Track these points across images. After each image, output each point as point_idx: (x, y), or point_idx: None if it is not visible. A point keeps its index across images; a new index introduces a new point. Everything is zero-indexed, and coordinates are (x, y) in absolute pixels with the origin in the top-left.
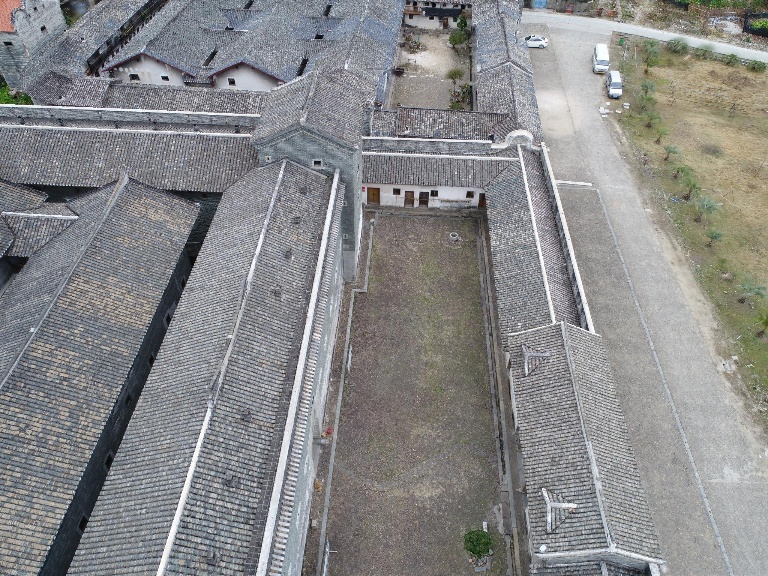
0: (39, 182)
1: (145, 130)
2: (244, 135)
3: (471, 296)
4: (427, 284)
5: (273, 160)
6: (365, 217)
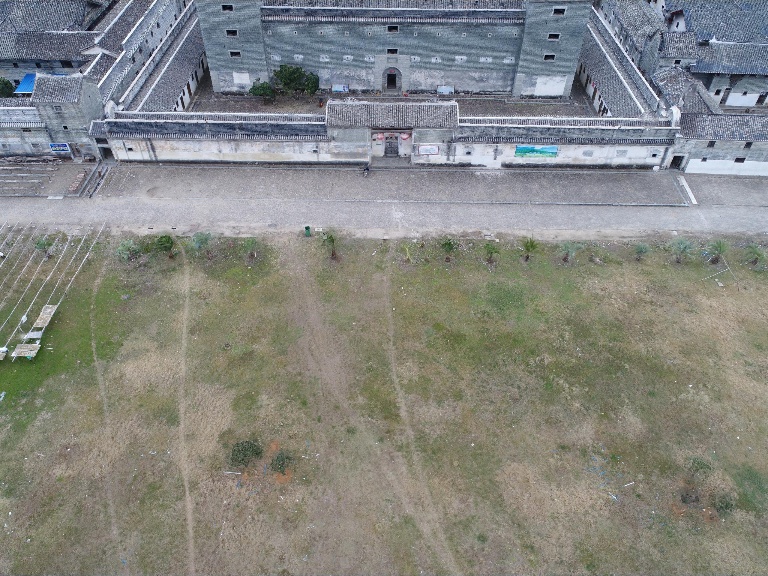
0: None
1: None
2: None
3: None
4: None
5: None
6: (578, 101)
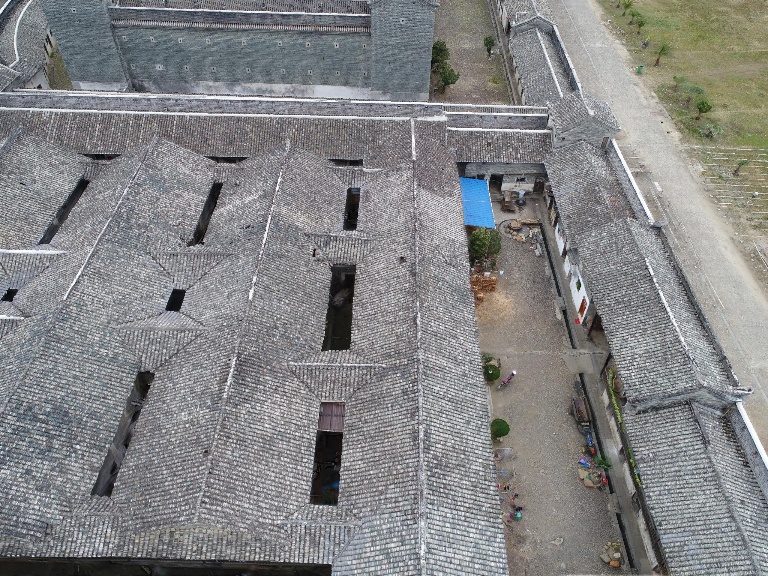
0: None
1: None
2: None
3: (483, 4)
4: (460, 1)
5: None
6: None
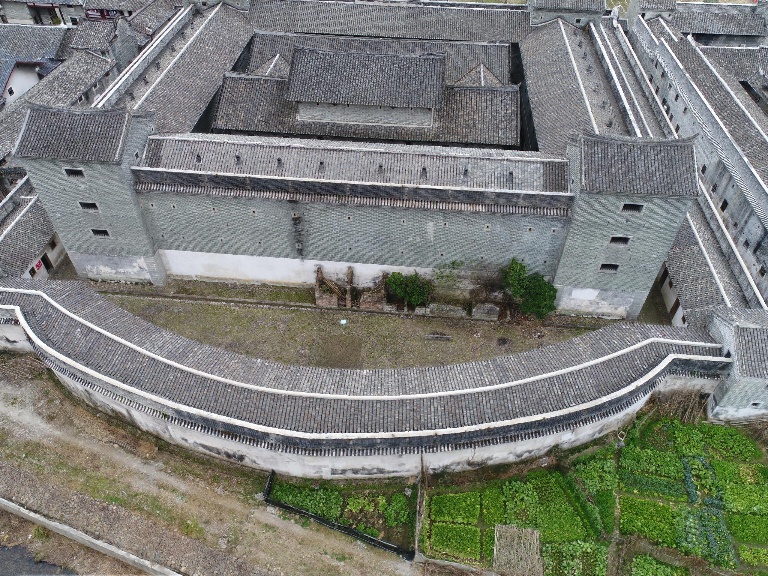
0: (221, 81)
1: (196, 32)
2: (218, 7)
3: None
4: None
5: (249, 2)
6: None
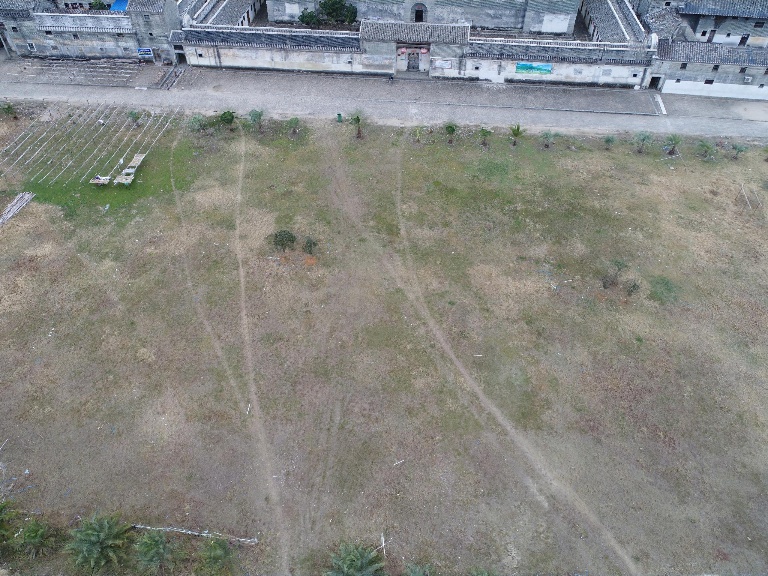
0: None
1: None
2: None
3: None
4: None
5: None
6: (580, 38)
